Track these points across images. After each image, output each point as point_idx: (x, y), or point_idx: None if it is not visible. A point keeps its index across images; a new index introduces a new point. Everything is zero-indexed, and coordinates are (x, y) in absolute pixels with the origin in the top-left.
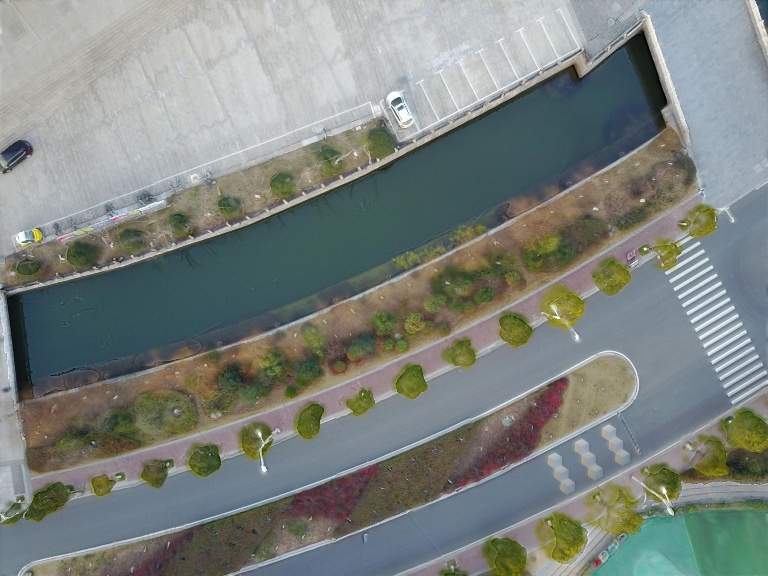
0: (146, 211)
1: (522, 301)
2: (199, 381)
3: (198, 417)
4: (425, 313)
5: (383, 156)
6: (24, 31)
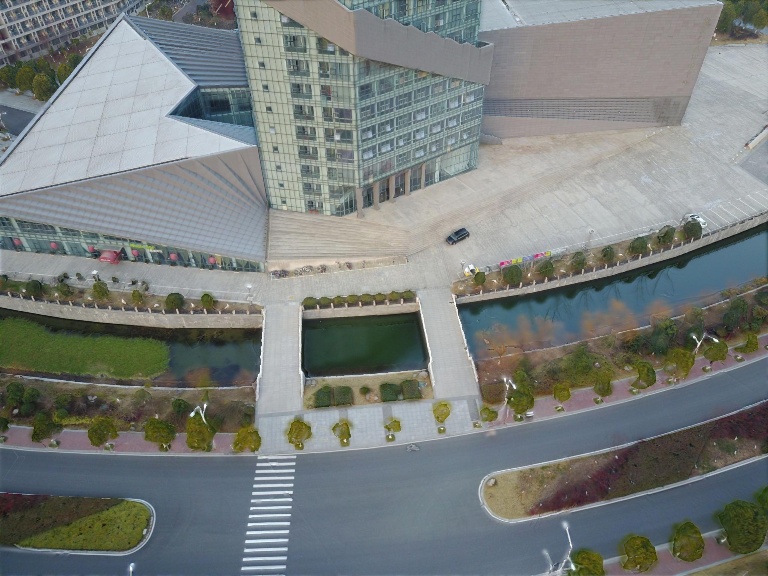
0: (554, 255)
1: None
2: (614, 340)
3: (614, 370)
4: (764, 307)
5: (696, 237)
6: (465, 188)
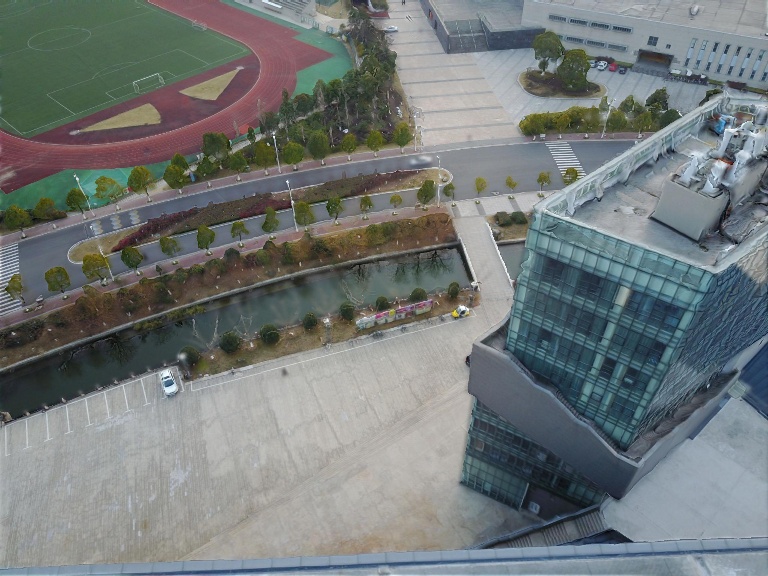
0: None
1: (124, 286)
2: None
3: None
4: (189, 273)
5: None
6: None
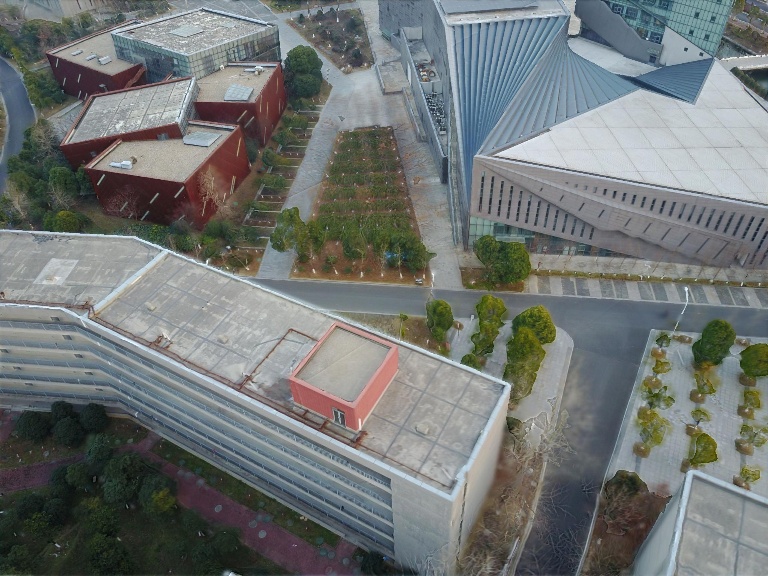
0: None
1: None
2: None
3: None
4: None
5: None
6: None
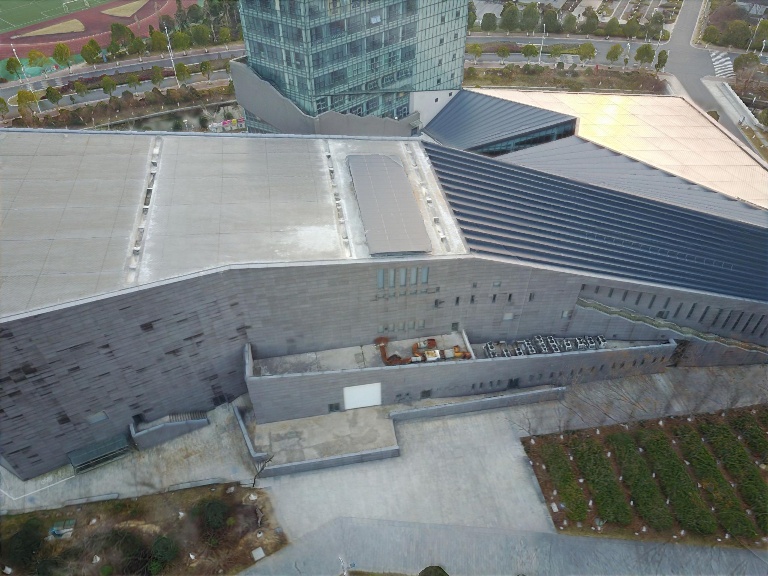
0: None
1: None
2: None
3: None
4: None
5: None
6: None
